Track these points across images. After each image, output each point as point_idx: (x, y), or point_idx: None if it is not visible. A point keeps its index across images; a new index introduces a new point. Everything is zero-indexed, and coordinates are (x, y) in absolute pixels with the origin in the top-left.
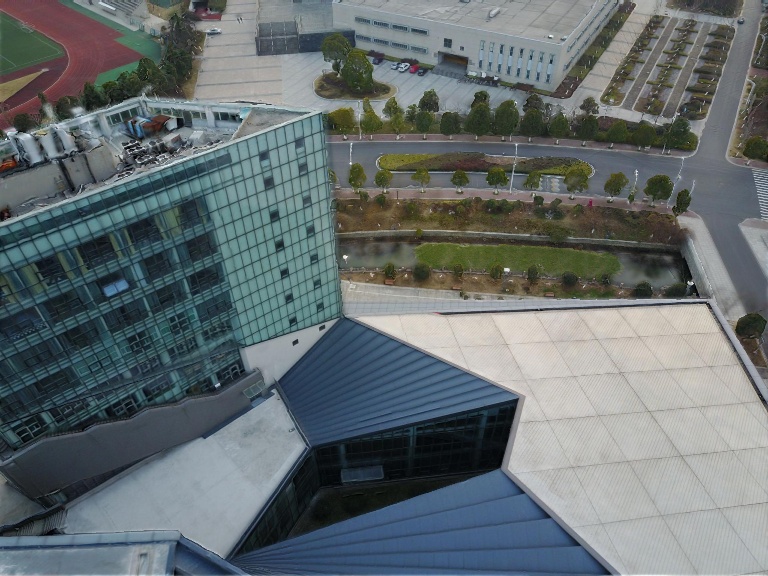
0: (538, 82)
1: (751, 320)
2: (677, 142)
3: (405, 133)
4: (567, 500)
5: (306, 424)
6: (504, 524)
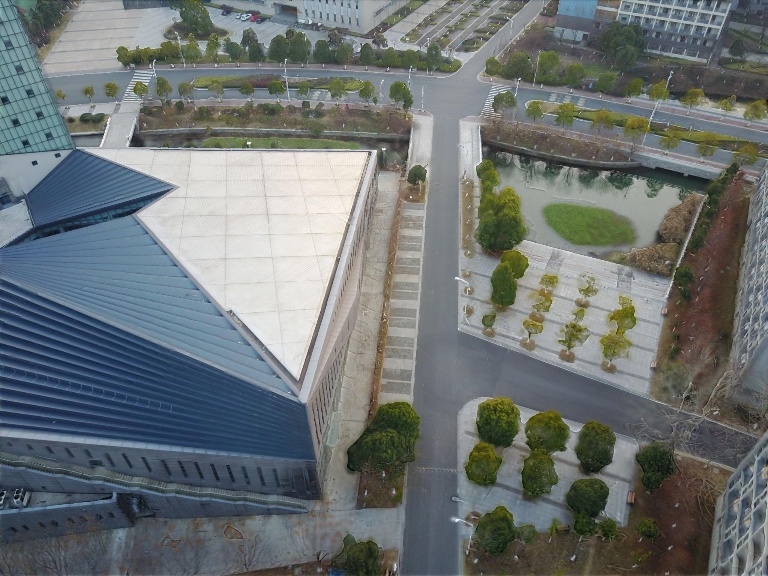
0: (351, 26)
1: (414, 169)
2: (433, 63)
3: (224, 63)
4: (166, 227)
5: (36, 215)
6: (118, 238)
